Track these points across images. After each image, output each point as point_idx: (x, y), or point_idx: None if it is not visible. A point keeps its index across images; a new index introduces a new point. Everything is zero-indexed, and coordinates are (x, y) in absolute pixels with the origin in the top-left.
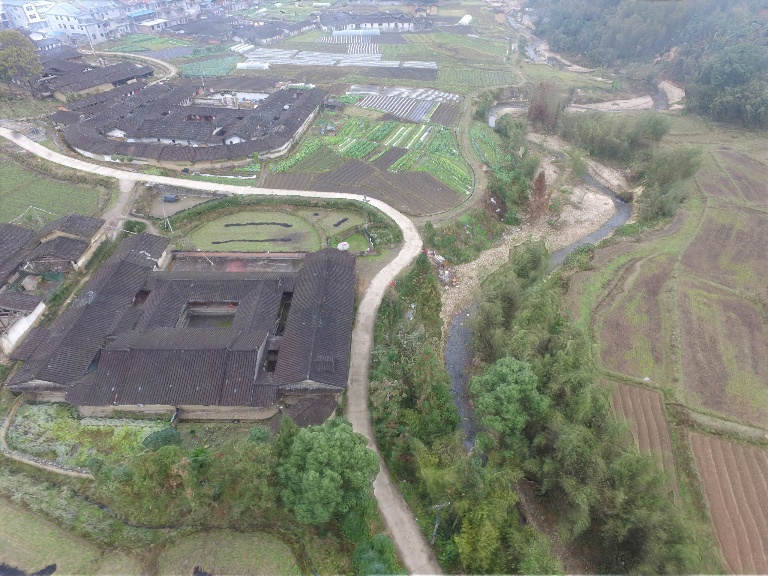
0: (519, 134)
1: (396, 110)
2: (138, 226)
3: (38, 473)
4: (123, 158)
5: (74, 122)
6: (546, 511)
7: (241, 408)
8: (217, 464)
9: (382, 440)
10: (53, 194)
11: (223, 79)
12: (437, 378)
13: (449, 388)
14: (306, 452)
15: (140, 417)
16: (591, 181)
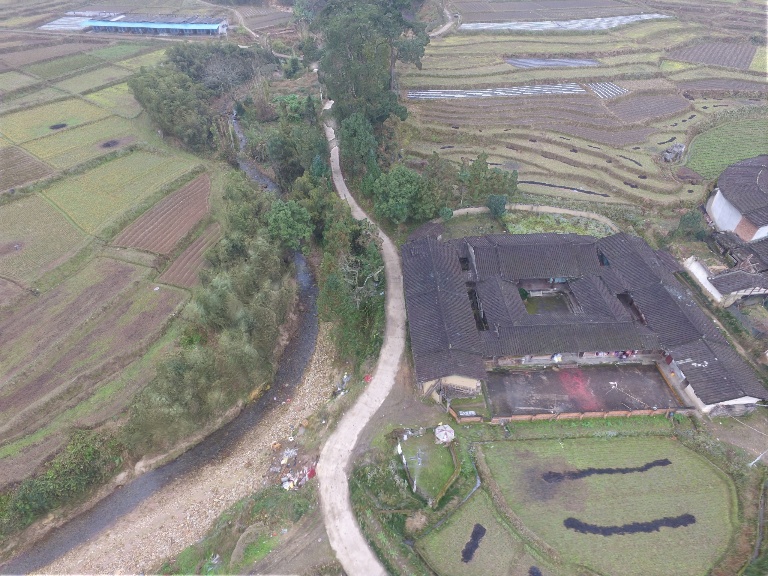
0: None
1: None
2: None
3: None
4: None
5: None
6: None
7: None
8: None
9: None
10: None
11: None
12: None
13: None
14: None
15: None
16: None
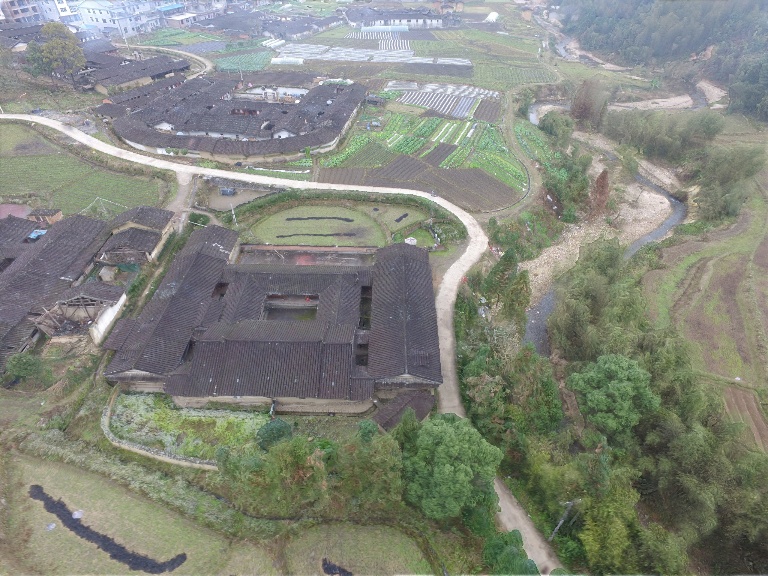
0: (569, 131)
1: (438, 106)
2: (202, 219)
3: (148, 462)
4: (178, 151)
5: (121, 115)
6: (650, 510)
7: (336, 401)
8: (347, 456)
9: (487, 435)
10: (112, 186)
11: (259, 74)
12: (548, 374)
13: (557, 384)
14: (435, 446)
15: (236, 409)
16: (642, 180)
